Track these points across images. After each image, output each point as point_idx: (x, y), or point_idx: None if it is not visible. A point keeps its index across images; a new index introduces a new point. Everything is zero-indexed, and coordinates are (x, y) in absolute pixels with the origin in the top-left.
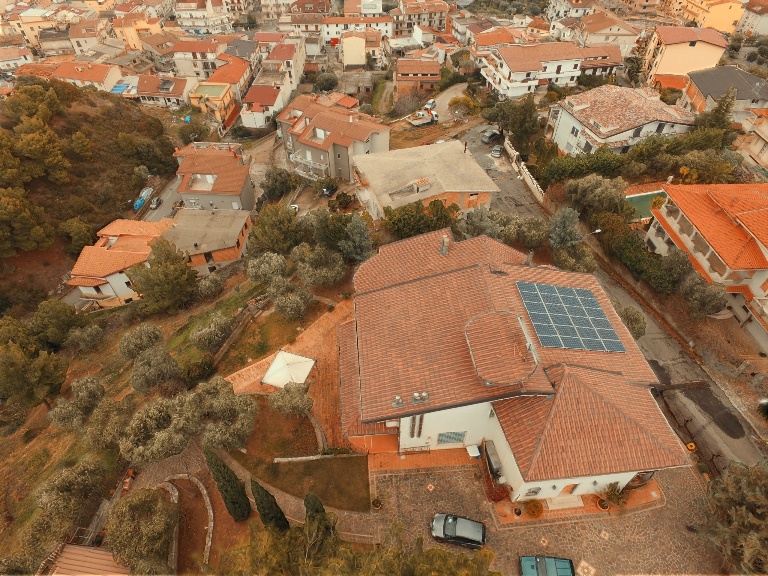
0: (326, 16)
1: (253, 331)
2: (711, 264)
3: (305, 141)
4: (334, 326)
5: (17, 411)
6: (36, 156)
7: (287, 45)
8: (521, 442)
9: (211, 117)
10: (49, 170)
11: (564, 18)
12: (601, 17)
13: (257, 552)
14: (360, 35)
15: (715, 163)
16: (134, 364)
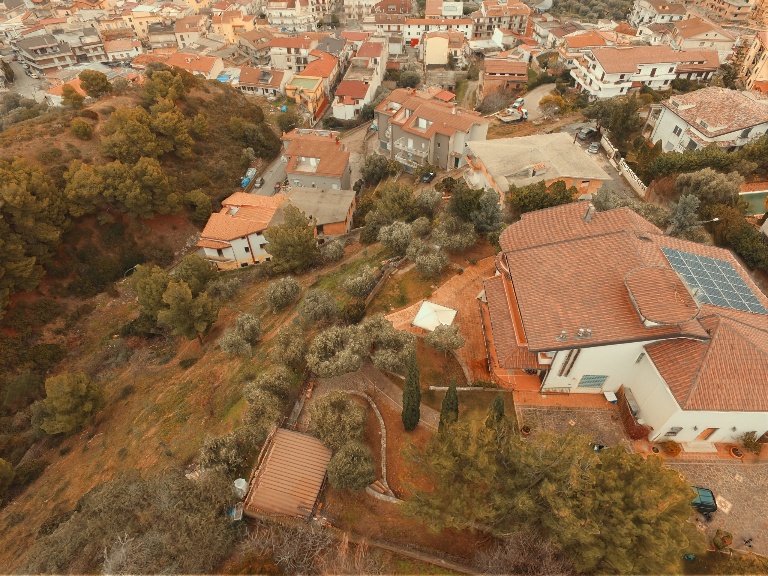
0: (407, 17)
1: (392, 285)
2: None
3: (409, 129)
4: (464, 287)
5: (163, 347)
6: (168, 133)
7: (374, 43)
8: (677, 378)
9: (304, 108)
10: (177, 146)
11: (652, 23)
12: (696, 22)
13: (481, 423)
14: (444, 36)
15: None
16: (274, 311)
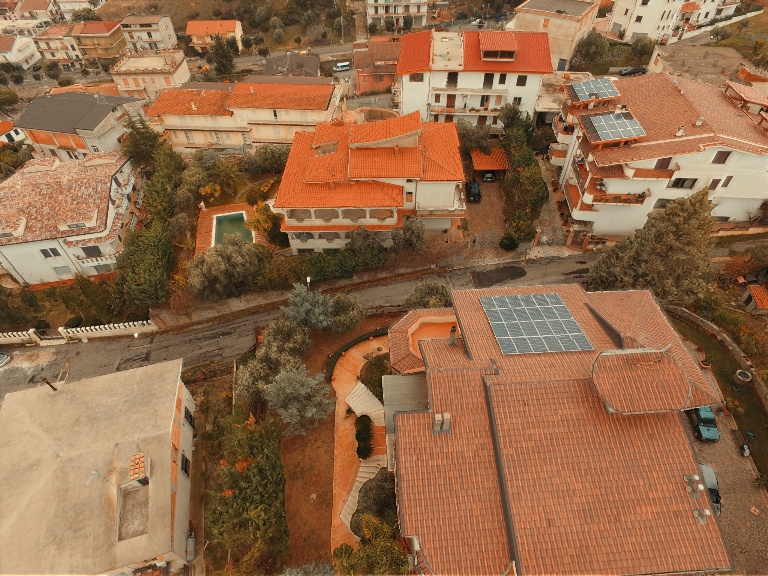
0: None
1: None
2: (376, 218)
3: None
4: None
5: None
6: None
7: None
8: None
9: None
10: None
11: None
12: None
13: None
14: None
15: (217, 167)
16: None
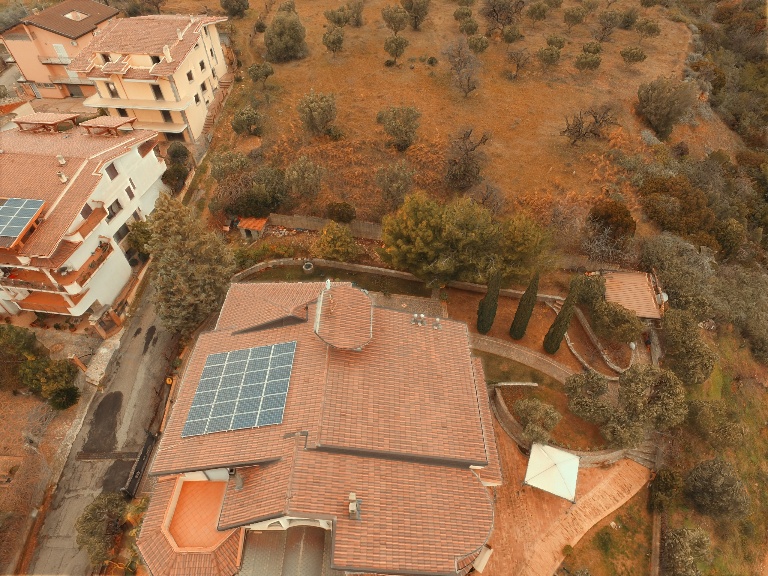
0: None
1: None
2: None
3: None
4: None
5: None
6: None
7: None
8: None
9: None
10: None
11: None
12: None
13: (520, 222)
14: None
15: None
16: None
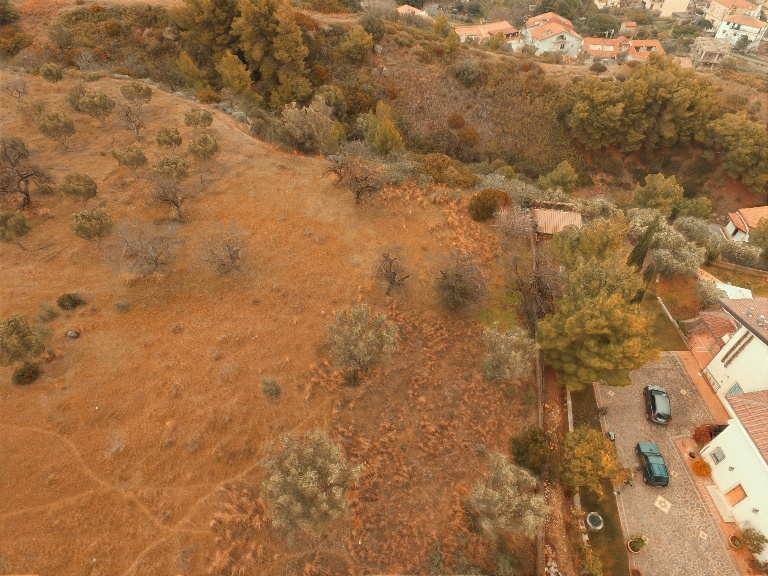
0: None
1: (759, 282)
2: None
3: None
4: None
5: None
6: None
7: None
8: (762, 396)
9: None
10: None
11: None
12: None
13: (620, 229)
14: None
15: None
16: None
